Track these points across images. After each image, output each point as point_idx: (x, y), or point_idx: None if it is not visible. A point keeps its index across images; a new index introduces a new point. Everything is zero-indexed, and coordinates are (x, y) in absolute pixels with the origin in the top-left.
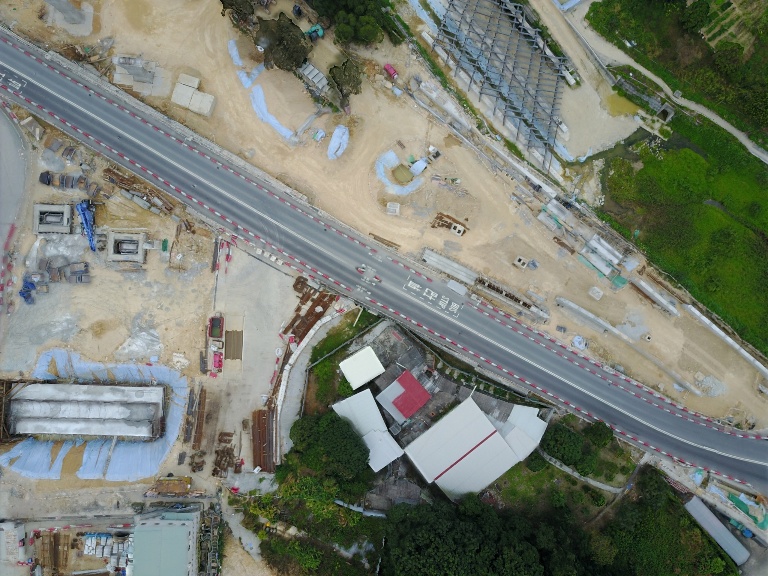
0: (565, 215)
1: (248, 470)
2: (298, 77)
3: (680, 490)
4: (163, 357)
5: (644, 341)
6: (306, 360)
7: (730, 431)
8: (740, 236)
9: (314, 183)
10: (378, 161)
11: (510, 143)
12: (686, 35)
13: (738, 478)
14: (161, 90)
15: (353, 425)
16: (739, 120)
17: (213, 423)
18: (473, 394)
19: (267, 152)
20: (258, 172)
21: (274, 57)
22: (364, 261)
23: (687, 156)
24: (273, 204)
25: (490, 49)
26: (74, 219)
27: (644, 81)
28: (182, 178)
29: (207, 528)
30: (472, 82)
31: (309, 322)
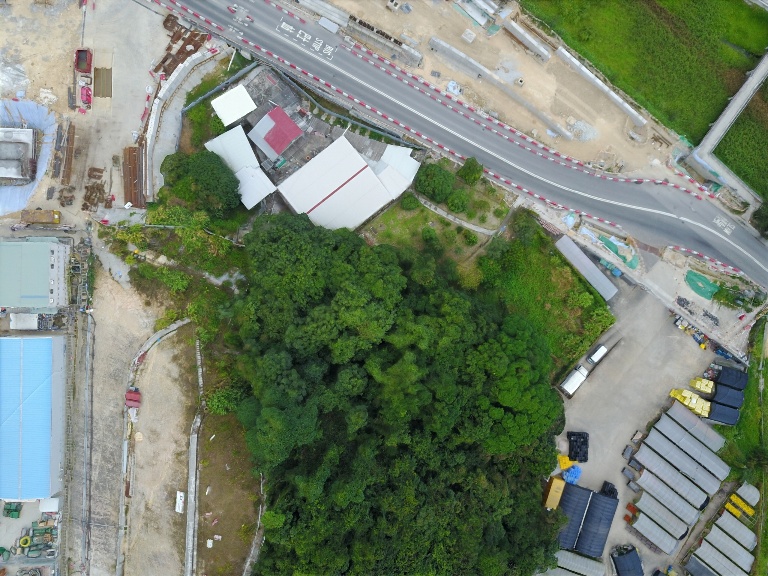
0: None
1: (119, 206)
2: None
3: (552, 231)
4: (30, 92)
5: (517, 86)
6: (180, 105)
7: (601, 174)
8: None
9: None
10: None
11: None
12: None
13: (608, 220)
14: None
15: (225, 163)
16: None
17: (82, 159)
18: (346, 133)
19: None
20: None
21: None
22: (236, 1)
23: None
24: None
25: None
26: None
27: None
28: None
29: (77, 261)
30: None
31: (180, 59)
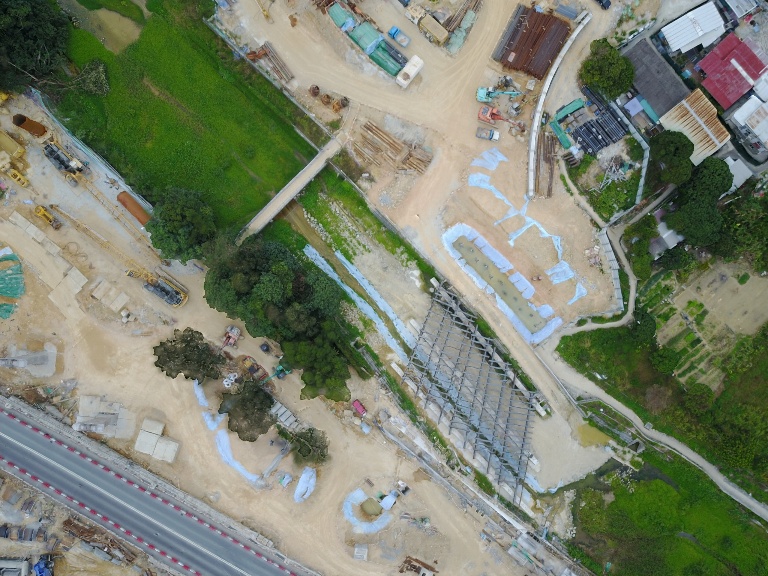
0: (536, 549)
1: None
2: None
3: None
4: None
5: None
6: None
7: None
8: (712, 571)
9: (280, 527)
10: (346, 501)
11: (480, 474)
12: (656, 385)
13: None
14: (125, 432)
15: None
16: (710, 455)
17: None
18: None
19: (233, 495)
20: (223, 518)
21: (238, 432)
22: None
23: (658, 489)
24: (238, 551)
25: (460, 380)
26: (32, 573)
27: (615, 417)
28: (145, 526)
29: None
30: (442, 415)
31: None
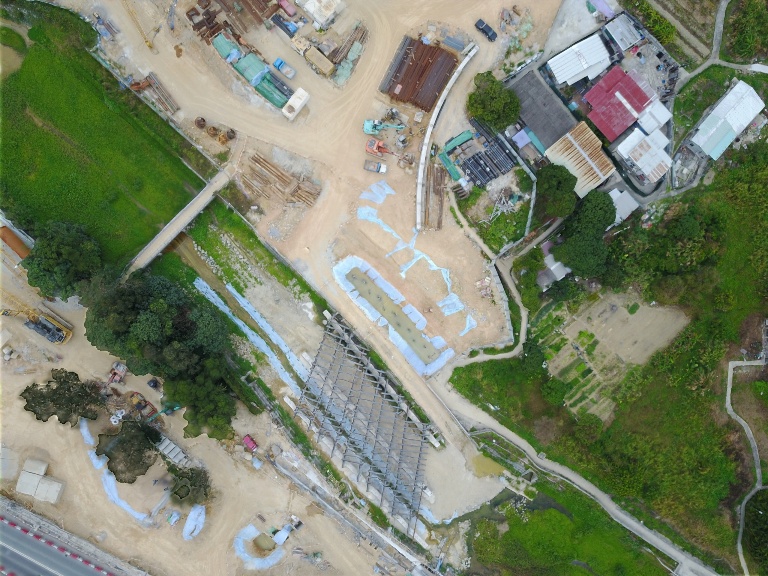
0: None
1: None
2: (154, 449)
3: None
4: None
5: None
6: None
7: None
8: None
9: (169, 565)
10: (236, 538)
11: (375, 507)
12: (543, 417)
13: None
14: (7, 472)
15: None
16: (602, 483)
17: None
18: None
19: (119, 534)
20: (109, 558)
21: (114, 474)
22: None
23: (552, 518)
24: None
25: (354, 413)
26: None
27: (507, 448)
28: (28, 568)
29: None
30: (335, 448)
31: None
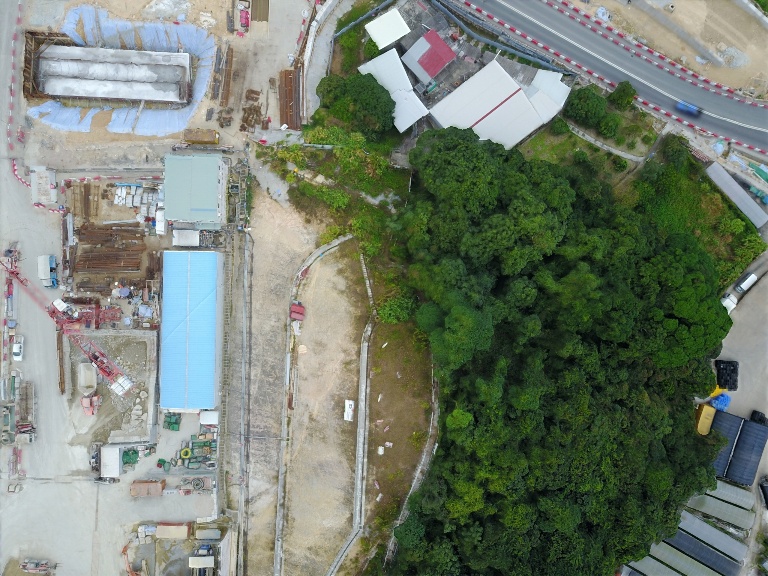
0: None
1: (275, 128)
2: None
3: (701, 158)
4: (190, 16)
5: (667, 12)
6: (331, 31)
7: (751, 101)
8: None
9: None
10: None
11: None
12: None
13: (758, 148)
14: None
15: None
16: None
17: (240, 81)
18: (497, 58)
19: None
20: None
21: None
22: None
23: None
24: None
25: None
26: None
27: None
28: None
29: (235, 181)
30: None
31: None
